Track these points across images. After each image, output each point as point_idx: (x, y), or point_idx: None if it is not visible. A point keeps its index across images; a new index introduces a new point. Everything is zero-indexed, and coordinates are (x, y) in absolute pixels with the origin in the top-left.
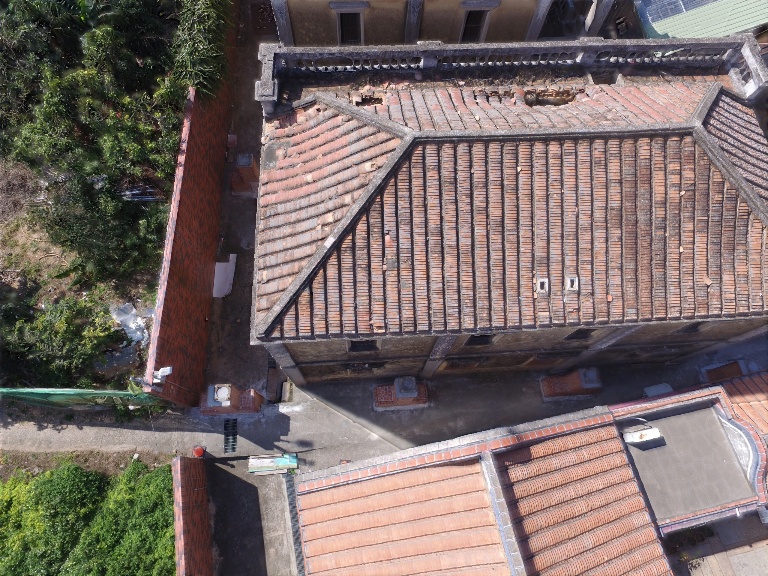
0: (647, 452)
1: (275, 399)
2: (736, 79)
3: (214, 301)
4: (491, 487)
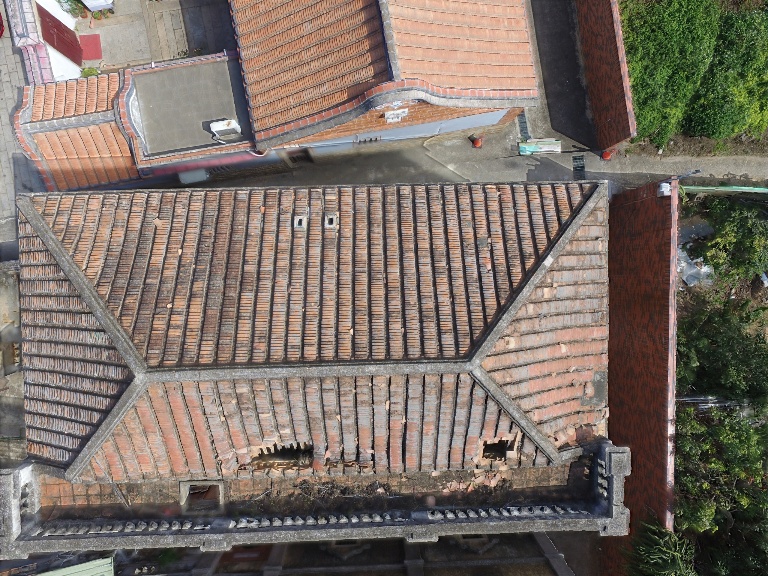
0: (222, 117)
1: None
2: (36, 495)
3: None
4: None
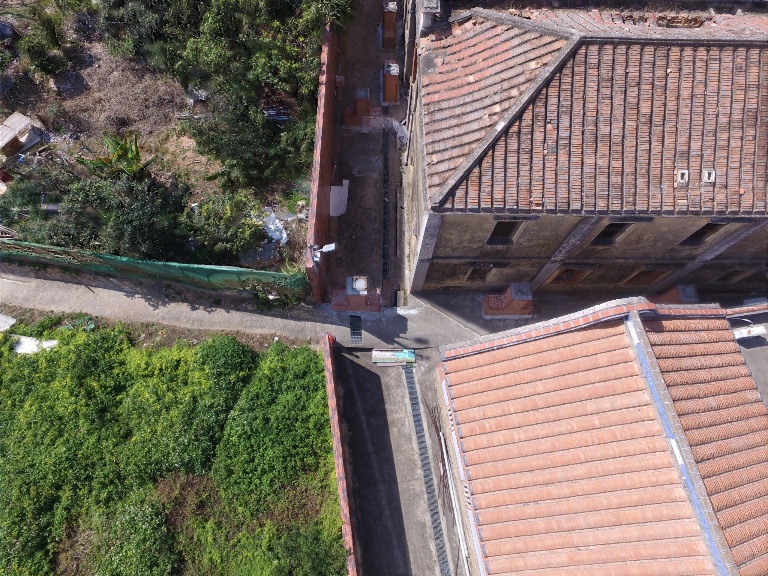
0: (751, 350)
1: (390, 305)
2: None
3: (330, 219)
4: (639, 341)
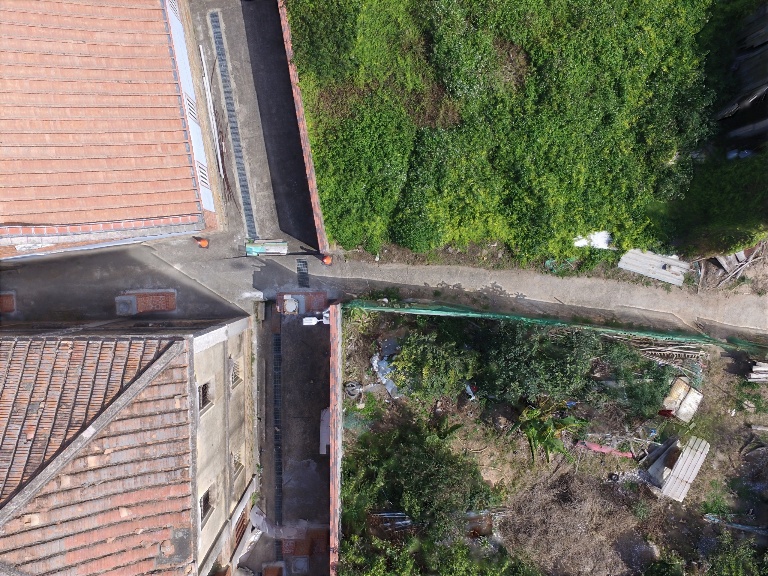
0: None
1: (272, 305)
2: None
3: None
4: None
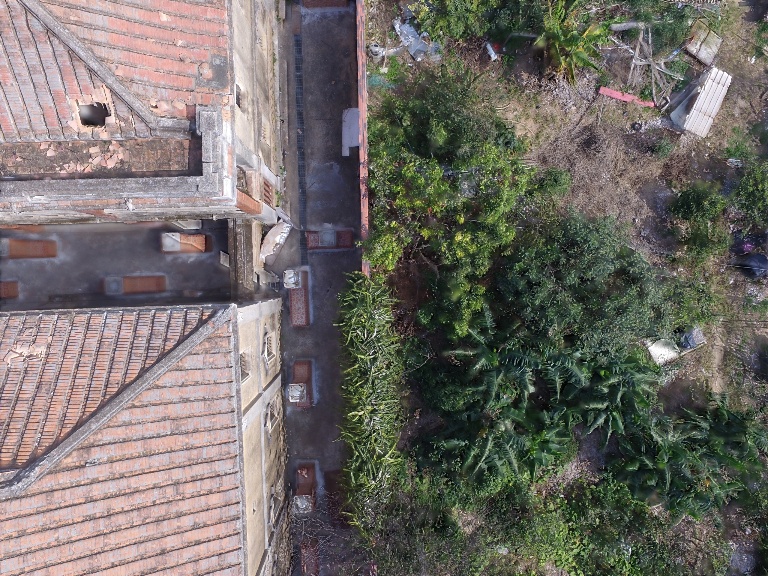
0: None
1: (293, 5)
2: None
3: None
4: None
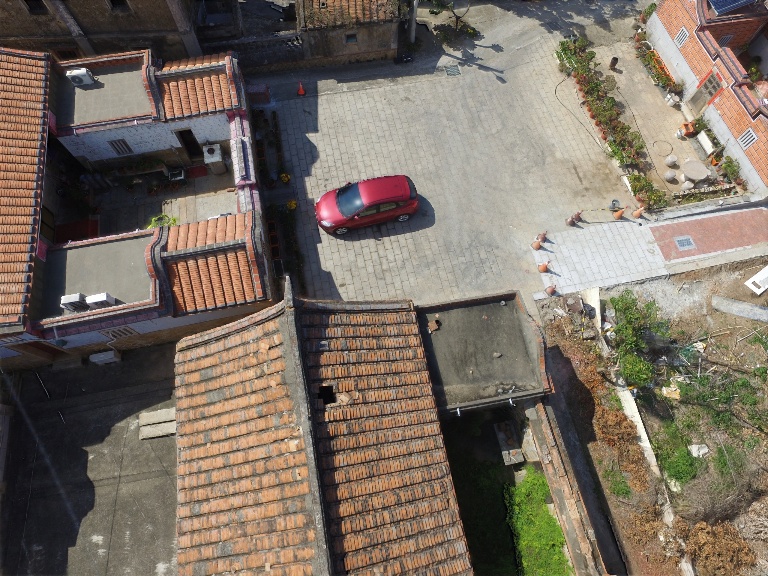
0: (87, 91)
1: None
2: None
3: None
4: None
